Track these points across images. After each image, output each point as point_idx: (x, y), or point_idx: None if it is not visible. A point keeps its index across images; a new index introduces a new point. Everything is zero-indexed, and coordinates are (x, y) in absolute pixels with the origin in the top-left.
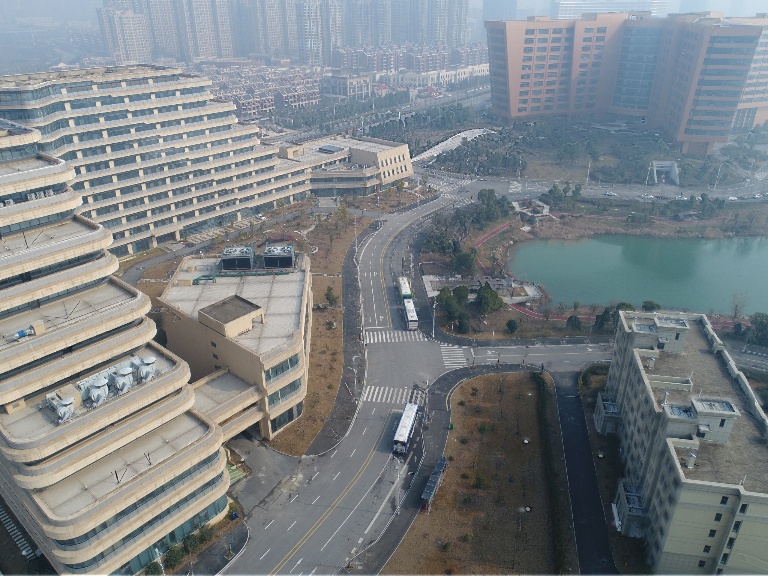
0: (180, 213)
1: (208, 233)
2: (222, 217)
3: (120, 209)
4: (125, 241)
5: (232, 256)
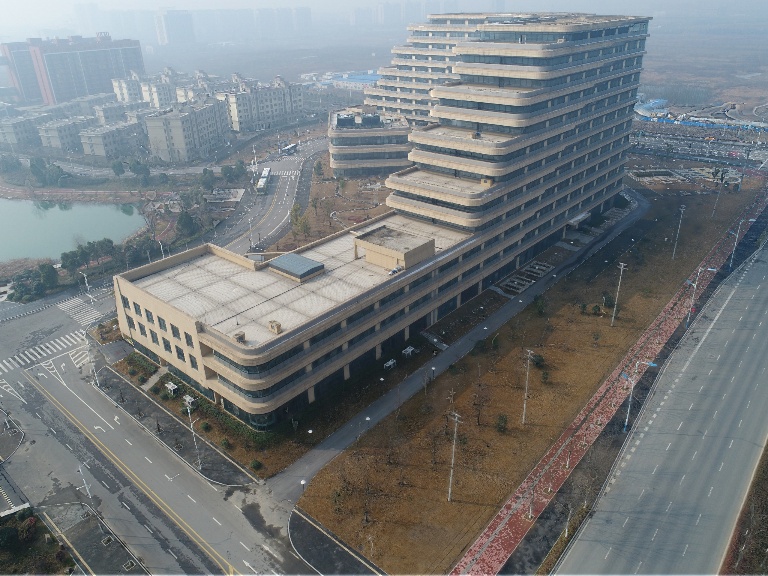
0: None
1: None
2: None
3: None
4: None
5: None
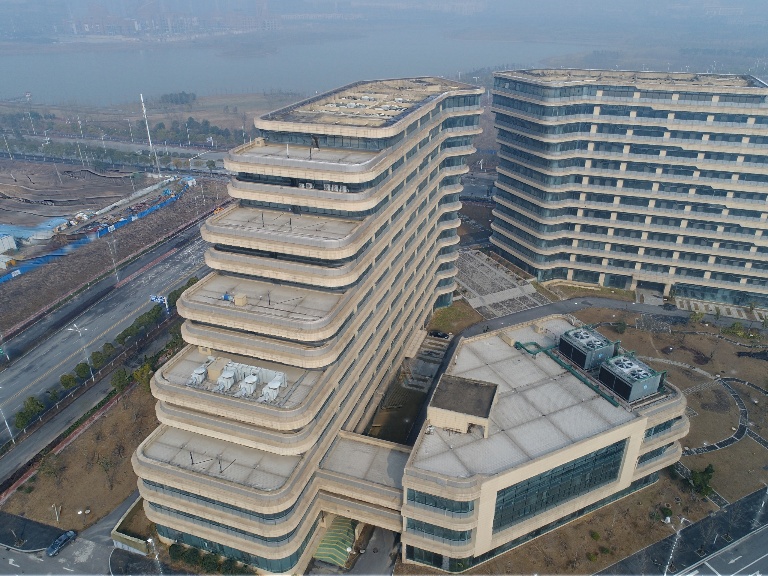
0: (682, 266)
1: (710, 304)
2: (745, 294)
3: (609, 234)
4: (599, 268)
5: (571, 341)
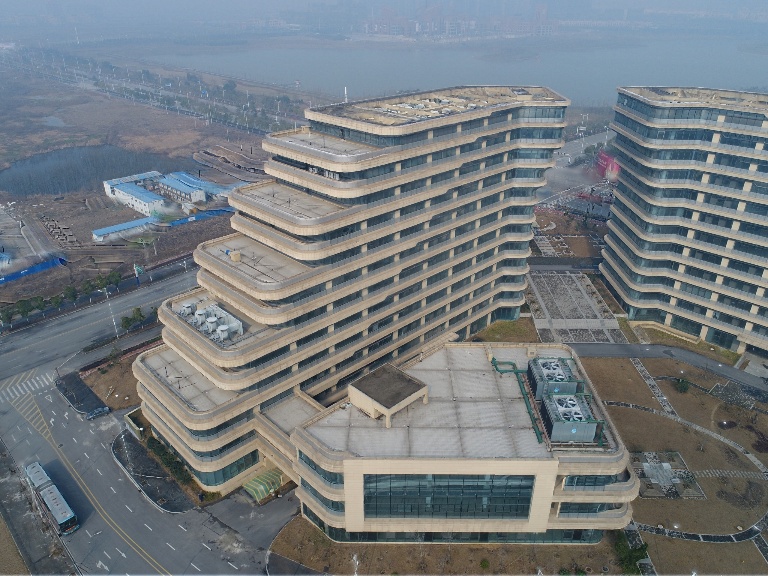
0: None
1: None
2: None
3: (717, 282)
4: (701, 319)
5: (533, 368)
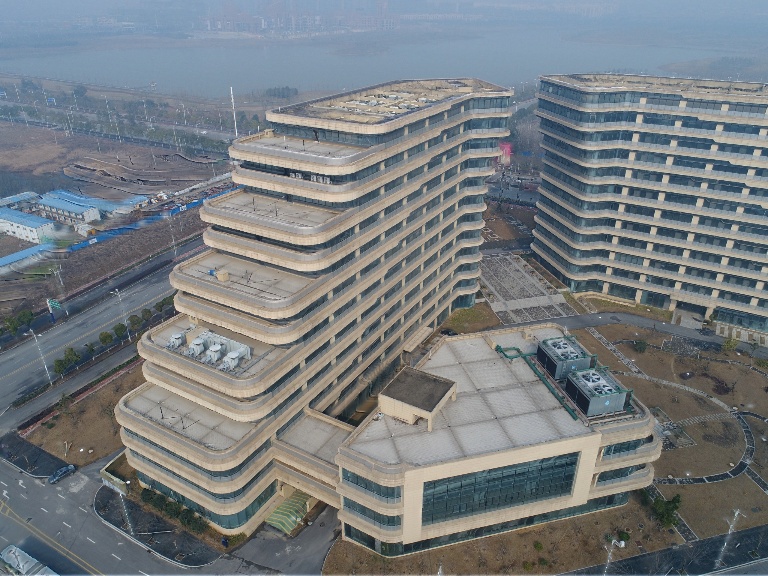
0: (726, 289)
1: (755, 334)
2: None
3: (648, 249)
4: (635, 284)
5: (546, 350)
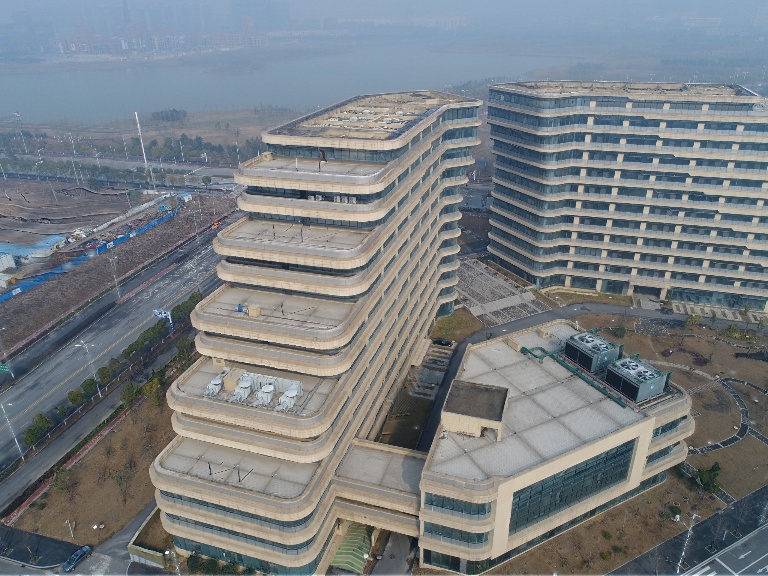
0: (677, 270)
1: (706, 308)
2: (739, 297)
3: (605, 240)
4: (596, 275)
5: (577, 345)
